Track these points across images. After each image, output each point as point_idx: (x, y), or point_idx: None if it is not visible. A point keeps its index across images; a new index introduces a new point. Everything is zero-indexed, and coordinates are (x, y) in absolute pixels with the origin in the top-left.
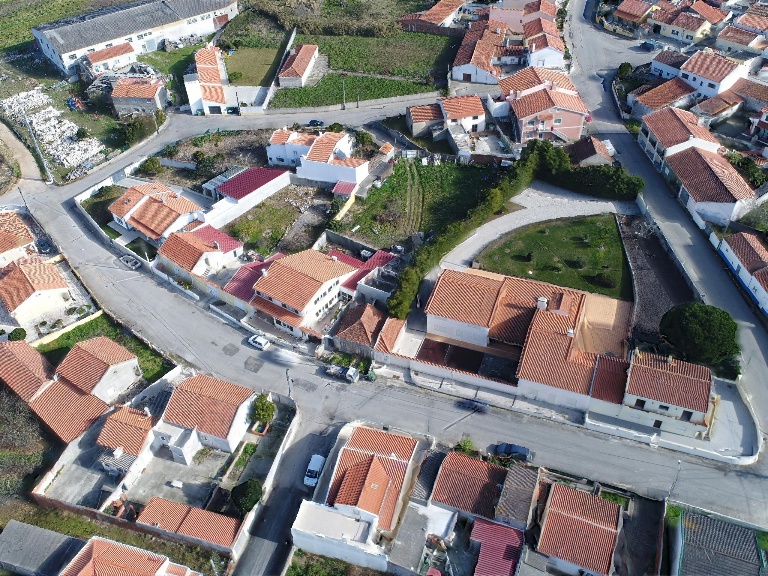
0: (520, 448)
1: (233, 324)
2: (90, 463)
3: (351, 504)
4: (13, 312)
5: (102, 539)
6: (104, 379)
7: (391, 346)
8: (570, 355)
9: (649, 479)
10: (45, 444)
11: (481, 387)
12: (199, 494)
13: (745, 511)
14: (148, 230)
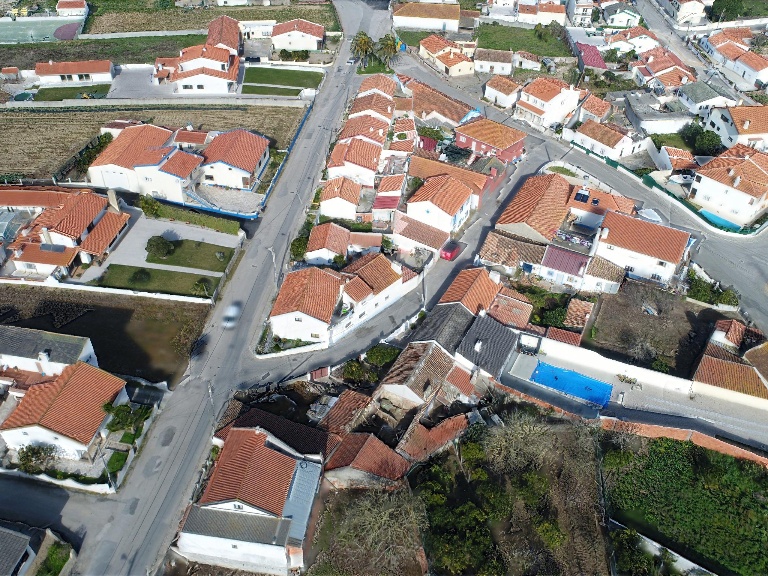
0: None
1: None
2: None
3: None
4: None
5: None
6: None
7: None
8: None
9: None
10: None
11: None
12: None
13: None
14: None
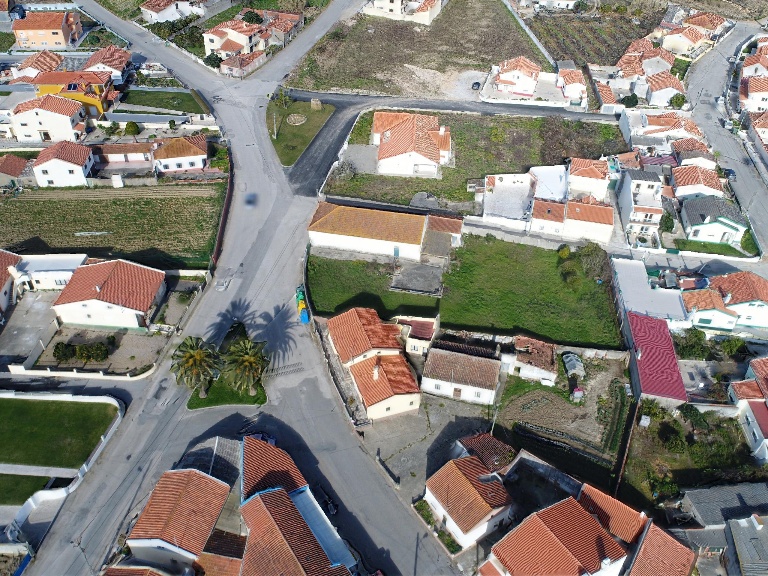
0: (733, 171)
1: (726, 93)
2: None
3: None
4: (665, 36)
5: None
6: (652, 60)
7: (760, 126)
8: None
9: (758, 216)
10: None
11: (766, 163)
12: None
13: None
14: (759, 52)
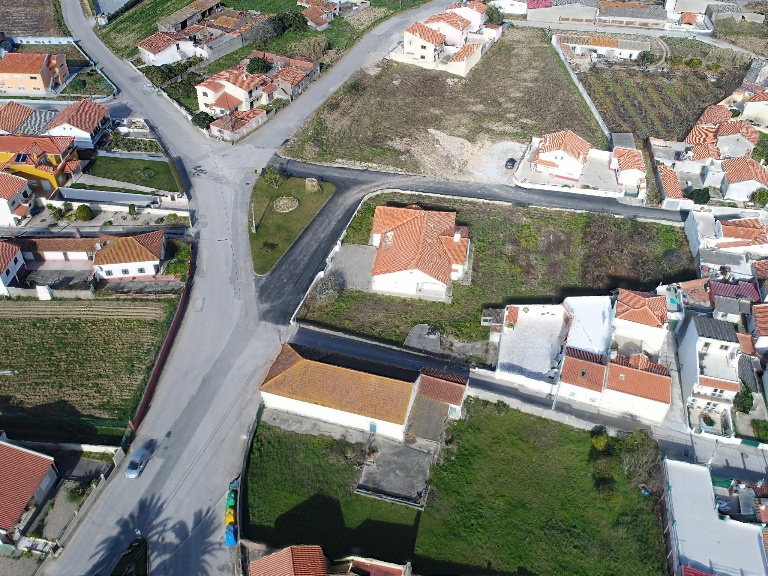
0: None
1: None
2: (679, 155)
3: (722, 224)
4: (747, 103)
5: (641, 153)
6: (730, 137)
7: None
8: None
9: None
10: (679, 141)
11: None
12: (690, 192)
13: None
14: None
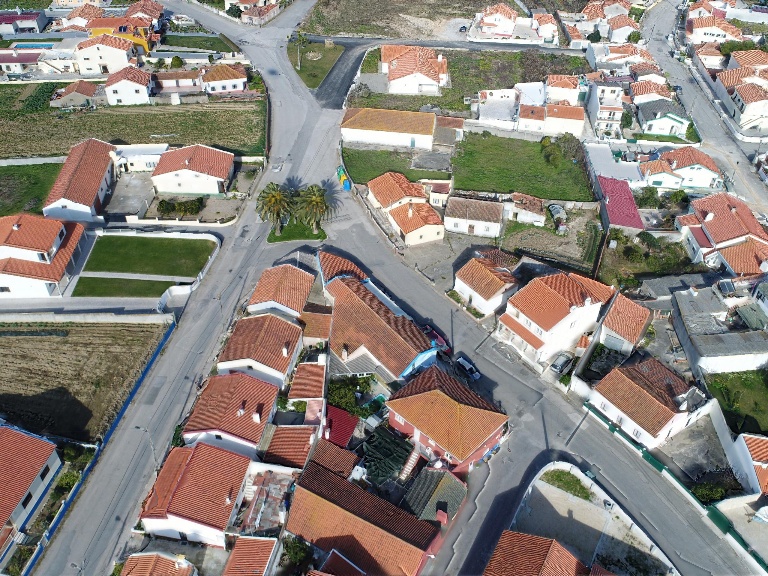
0: None
1: (675, 32)
2: None
3: None
4: None
5: None
6: (612, 7)
7: (702, 54)
8: (744, 78)
9: (700, 117)
10: None
11: None
12: None
13: (708, 137)
14: None
